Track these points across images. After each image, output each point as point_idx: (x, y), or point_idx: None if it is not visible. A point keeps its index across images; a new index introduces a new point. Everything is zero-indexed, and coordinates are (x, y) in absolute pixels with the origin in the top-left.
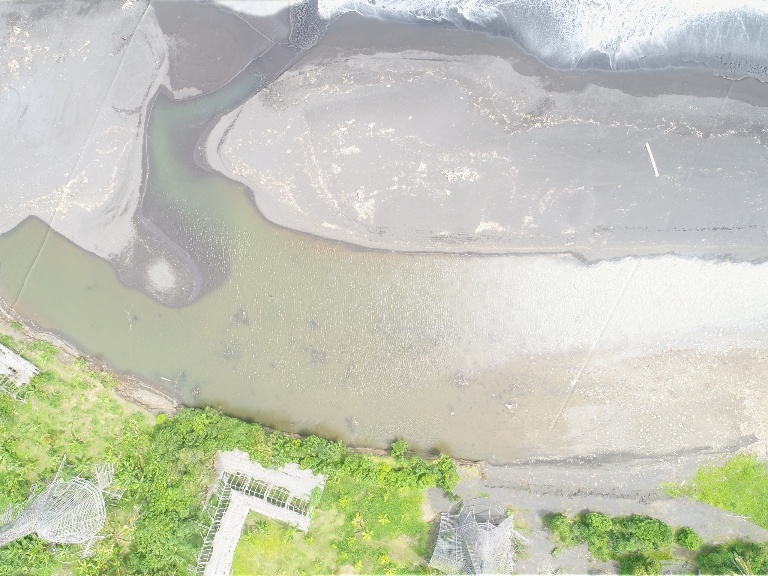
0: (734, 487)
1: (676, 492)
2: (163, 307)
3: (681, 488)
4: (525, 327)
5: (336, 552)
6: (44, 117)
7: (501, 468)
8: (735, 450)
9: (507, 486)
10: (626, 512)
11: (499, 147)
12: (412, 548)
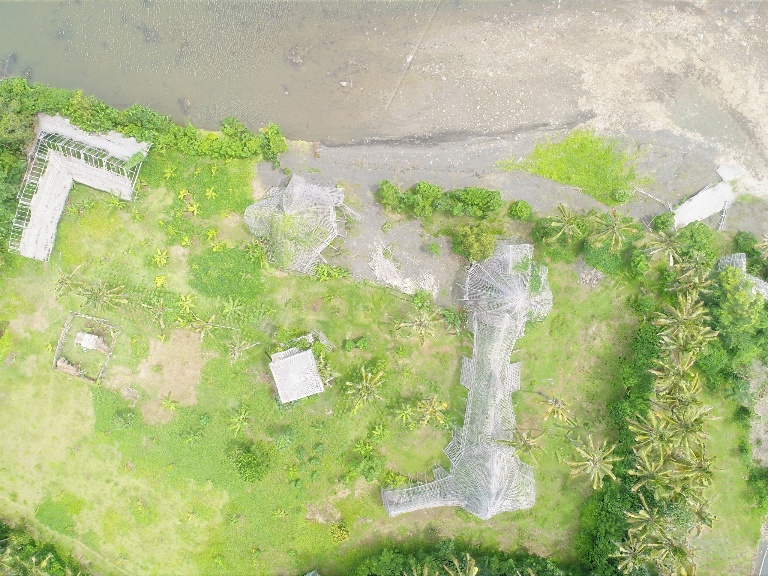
0: (570, 161)
1: (511, 167)
2: None
3: (517, 164)
4: (360, 2)
5: (165, 232)
6: None
7: (336, 148)
8: (573, 126)
9: (339, 163)
10: (459, 186)
11: None
12: (242, 227)
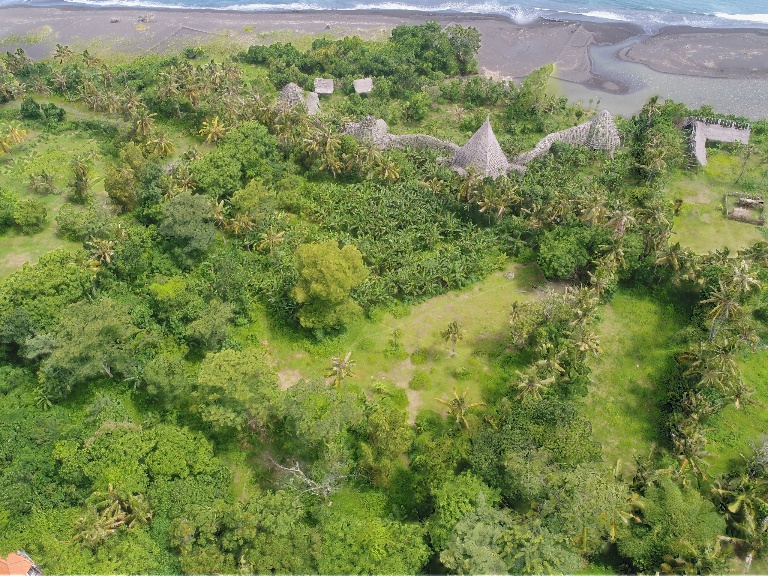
0: None
1: None
2: (614, 95)
3: None
4: None
5: None
6: (538, 48)
7: None
8: None
9: None
10: None
11: (766, 48)
12: None
